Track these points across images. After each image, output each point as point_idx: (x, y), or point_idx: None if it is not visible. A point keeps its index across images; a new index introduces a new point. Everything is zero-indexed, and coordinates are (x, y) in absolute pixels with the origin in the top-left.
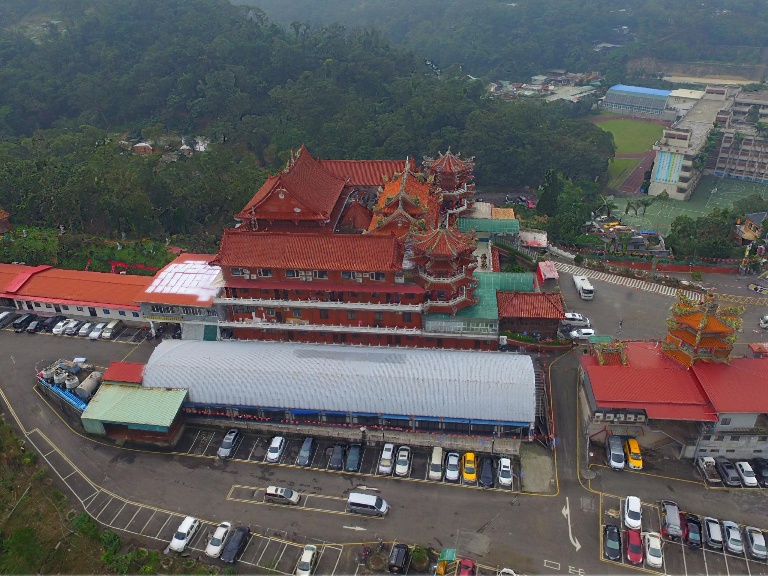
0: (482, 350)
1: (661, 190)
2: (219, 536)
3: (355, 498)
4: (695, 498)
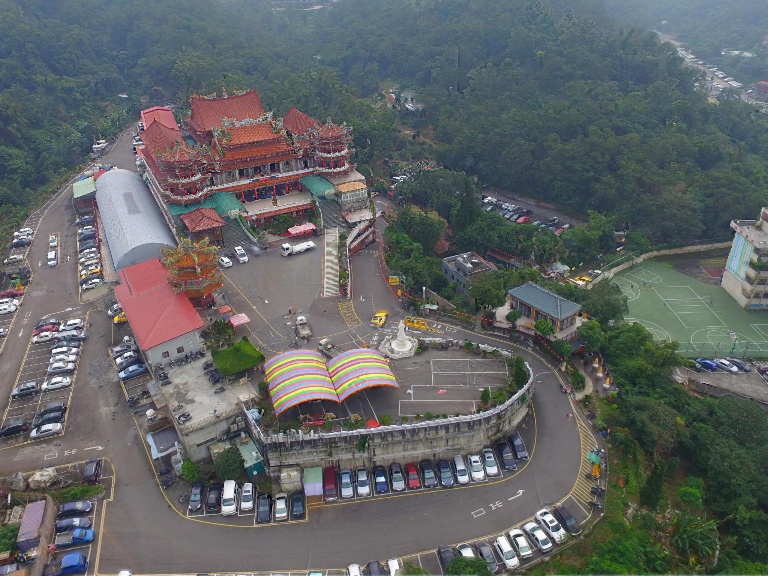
0: None
1: None
2: (21, 237)
3: None
4: (97, 345)
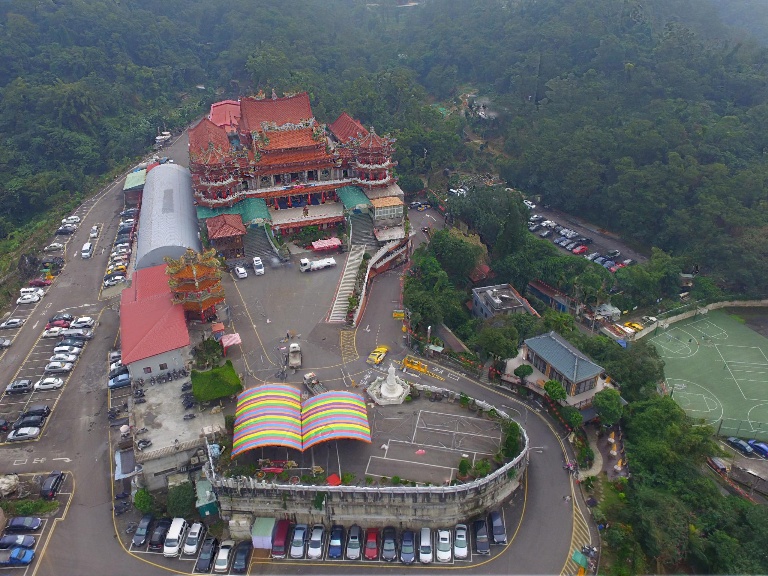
0: None
1: None
2: None
3: (87, 244)
4: (99, 347)
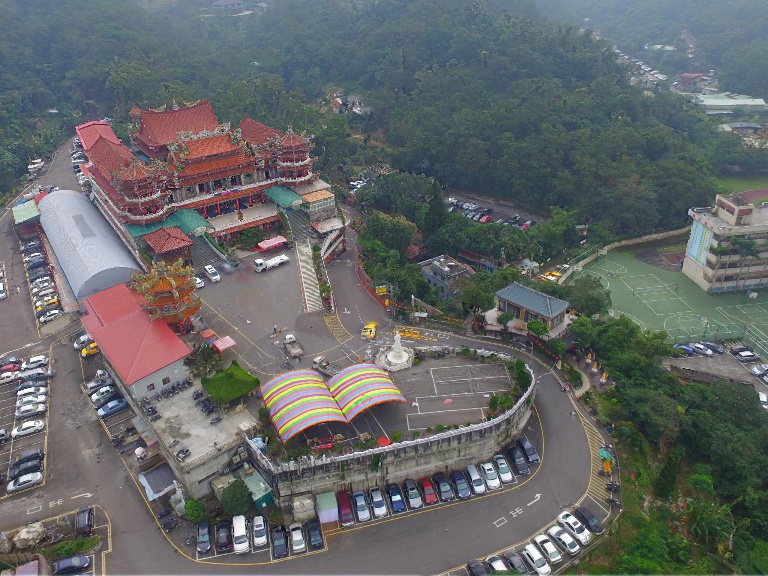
0: (140, 259)
1: (692, 270)
2: None
3: None
4: (67, 382)
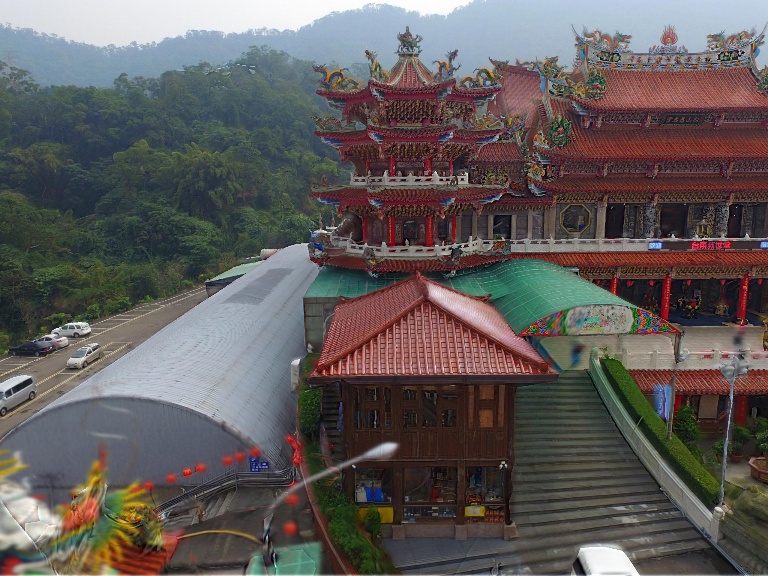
0: None
1: None
2: None
3: (16, 377)
4: None
